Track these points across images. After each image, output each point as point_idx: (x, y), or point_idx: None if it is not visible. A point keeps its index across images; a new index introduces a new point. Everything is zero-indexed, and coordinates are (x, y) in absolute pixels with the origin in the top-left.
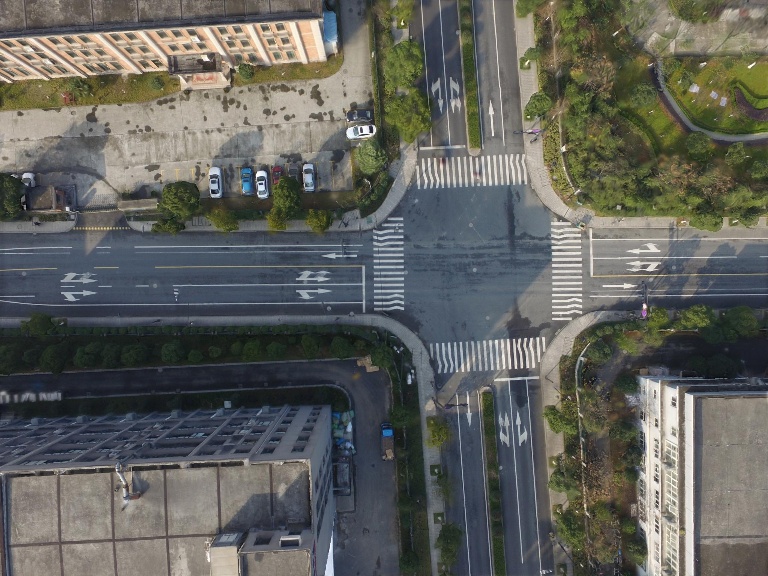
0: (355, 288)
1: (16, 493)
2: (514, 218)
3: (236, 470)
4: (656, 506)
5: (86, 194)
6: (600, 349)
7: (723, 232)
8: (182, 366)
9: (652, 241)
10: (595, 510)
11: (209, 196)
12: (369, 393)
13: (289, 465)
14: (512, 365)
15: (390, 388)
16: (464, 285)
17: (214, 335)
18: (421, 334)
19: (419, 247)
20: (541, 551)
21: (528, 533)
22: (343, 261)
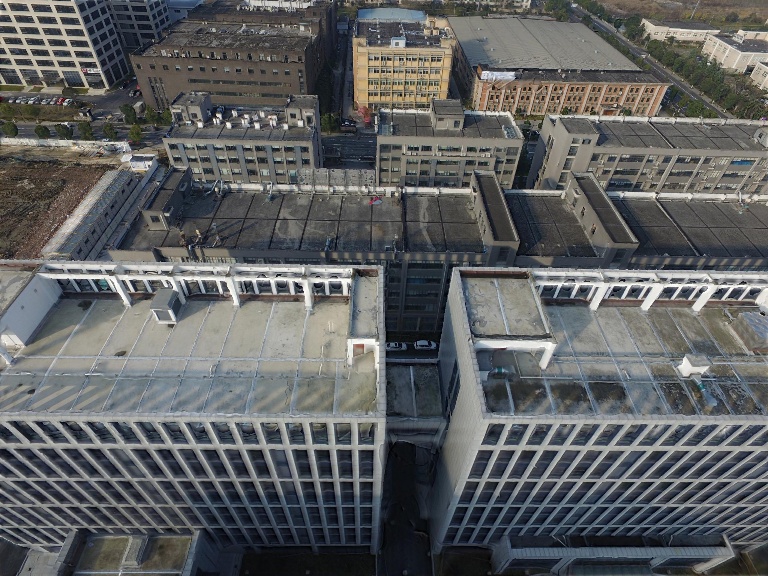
0: None
1: None
2: None
3: None
4: None
5: None
6: None
7: None
8: None
9: None
10: None
11: None
12: None
13: None
14: None
15: None
16: None
17: None
18: None
19: None
20: None
21: None
22: None
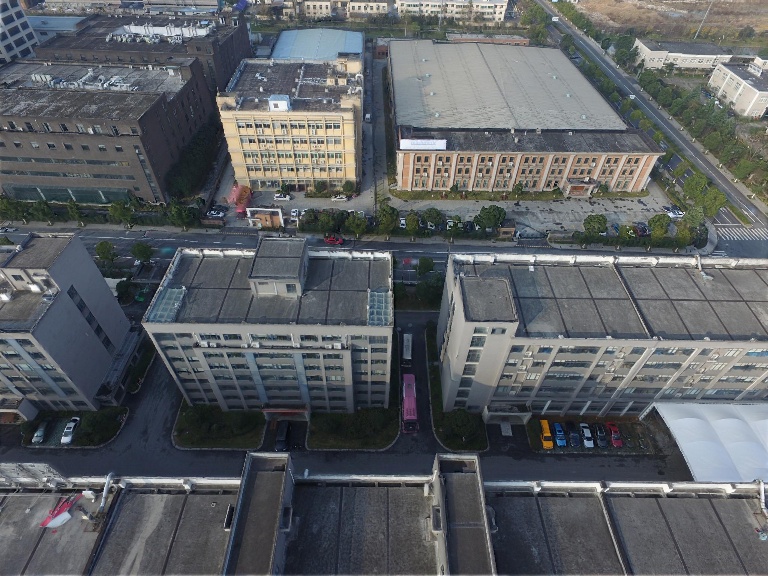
0: None
1: (626, 274)
2: None
3: (767, 272)
4: None
5: (521, 232)
6: None
7: None
8: None
9: None
10: None
11: (599, 234)
12: None
13: None
14: None
15: None
16: None
17: None
18: None
19: None
20: None
21: None
22: None
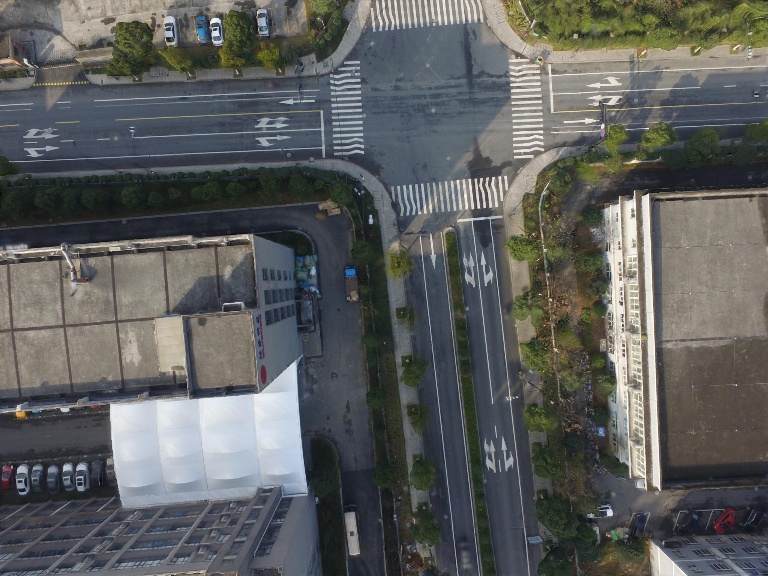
0: (314, 133)
1: None
2: (471, 57)
3: (182, 254)
4: (622, 330)
5: (44, 50)
6: (561, 177)
7: (685, 63)
8: (145, 217)
9: (613, 75)
10: (563, 344)
11: (165, 45)
12: (332, 237)
13: (234, 247)
14: (475, 205)
15: (353, 232)
16: (423, 126)
17: (175, 183)
18: (382, 177)
19: (376, 90)
20: (511, 391)
21: (497, 374)
22: (301, 107)
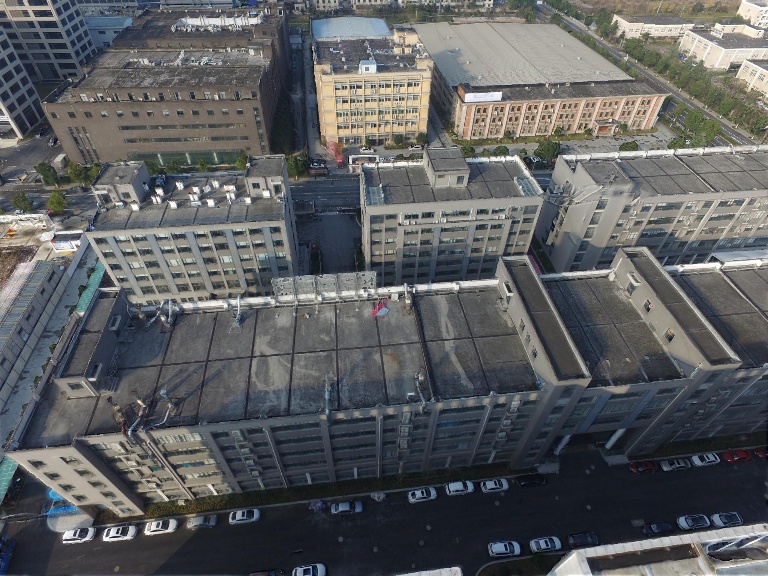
0: None
1: None
2: None
3: None
4: None
5: None
6: None
7: None
8: None
9: None
10: None
11: None
12: None
13: None
14: None
15: None
16: None
17: None
18: None
19: None
20: None
21: None
22: None
